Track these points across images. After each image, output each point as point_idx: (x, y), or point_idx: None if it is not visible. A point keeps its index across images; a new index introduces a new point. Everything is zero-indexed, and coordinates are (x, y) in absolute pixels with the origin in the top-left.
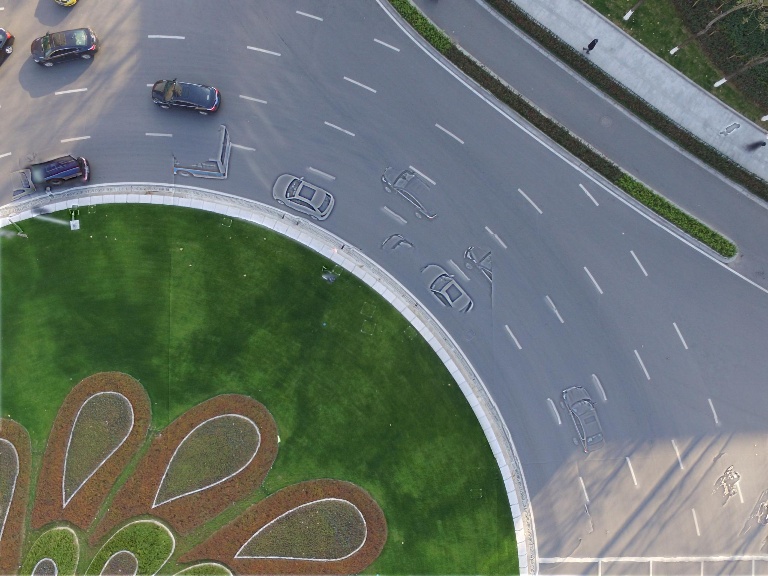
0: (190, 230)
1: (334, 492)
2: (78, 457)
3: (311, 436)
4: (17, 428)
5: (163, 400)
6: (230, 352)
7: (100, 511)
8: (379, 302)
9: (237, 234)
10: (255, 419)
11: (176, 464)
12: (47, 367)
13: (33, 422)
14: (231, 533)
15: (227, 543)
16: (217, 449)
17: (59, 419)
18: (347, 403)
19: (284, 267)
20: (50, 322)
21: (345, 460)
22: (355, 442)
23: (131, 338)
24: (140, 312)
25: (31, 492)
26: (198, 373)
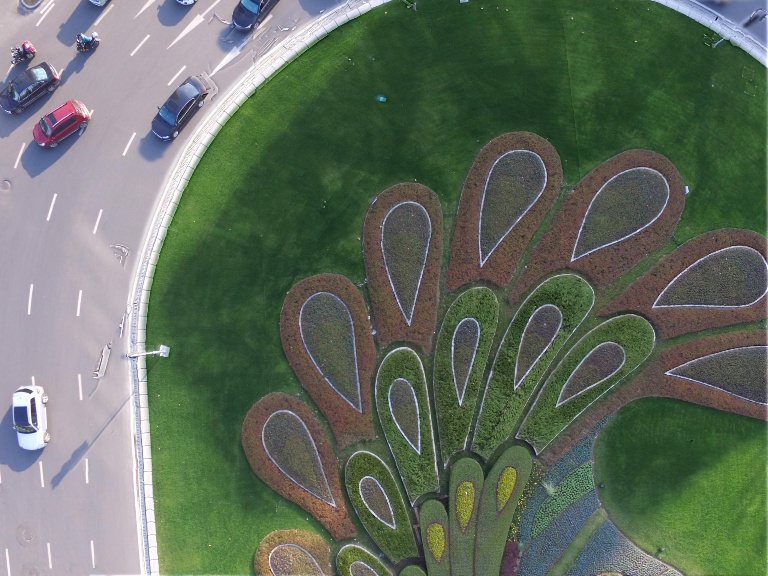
0: (576, 2)
1: (741, 239)
2: (495, 214)
3: (713, 188)
4: (427, 190)
5: (573, 157)
6: (631, 111)
7: (517, 269)
8: (757, 67)
9: (621, 6)
10: (664, 171)
11: (593, 216)
12: (452, 131)
13: (442, 185)
14: (650, 281)
15: (647, 292)
16: (633, 199)
17: (472, 178)
18: (742, 157)
19: (669, 35)
20: (451, 88)
21: (745, 210)
22: (753, 193)
23: (534, 100)
24: (541, 76)
25: (445, 254)
26: (603, 131)
